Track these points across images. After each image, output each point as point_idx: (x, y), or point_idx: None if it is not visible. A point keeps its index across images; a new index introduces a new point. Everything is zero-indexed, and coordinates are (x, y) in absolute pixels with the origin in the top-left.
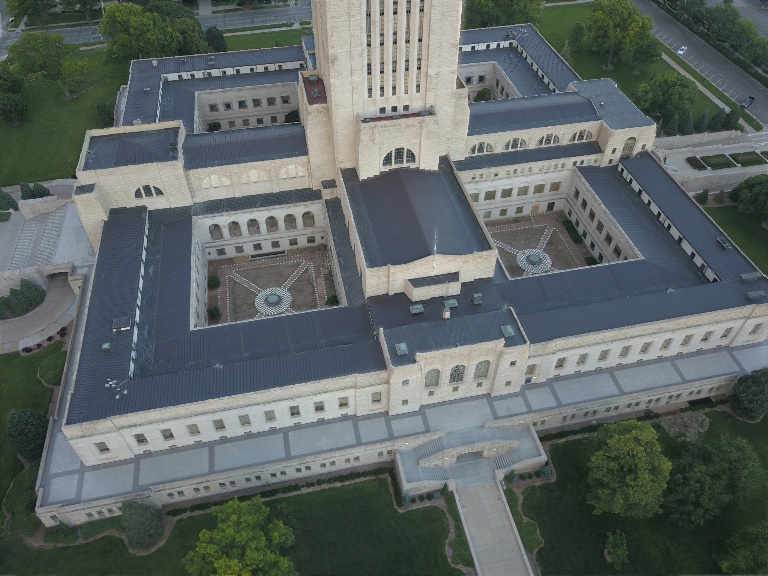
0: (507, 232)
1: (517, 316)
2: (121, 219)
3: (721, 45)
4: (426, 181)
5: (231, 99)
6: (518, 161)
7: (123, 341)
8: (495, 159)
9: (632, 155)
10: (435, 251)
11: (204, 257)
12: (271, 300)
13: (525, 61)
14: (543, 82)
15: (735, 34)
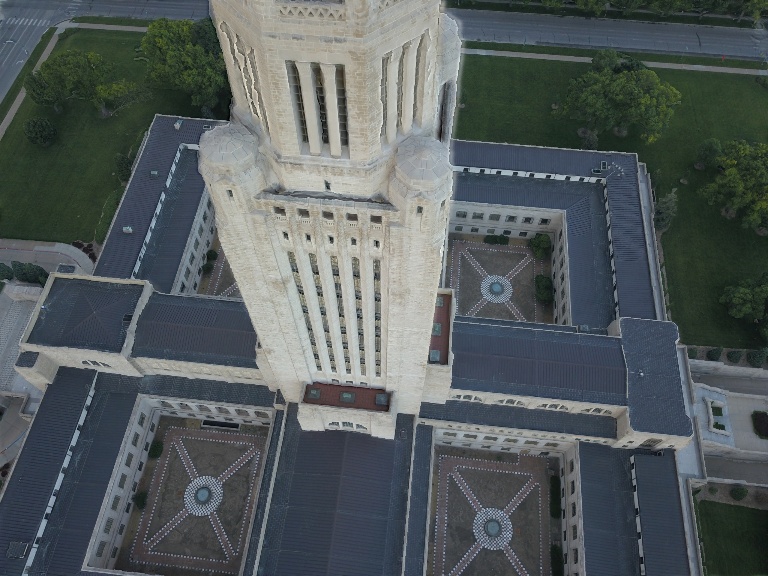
0: (482, 472)
1: None
2: (66, 384)
3: None
4: (372, 457)
5: None
6: (508, 422)
7: (13, 571)
8: (482, 411)
9: (655, 447)
10: None
11: (151, 422)
12: (200, 496)
13: (604, 216)
14: (610, 263)
15: None
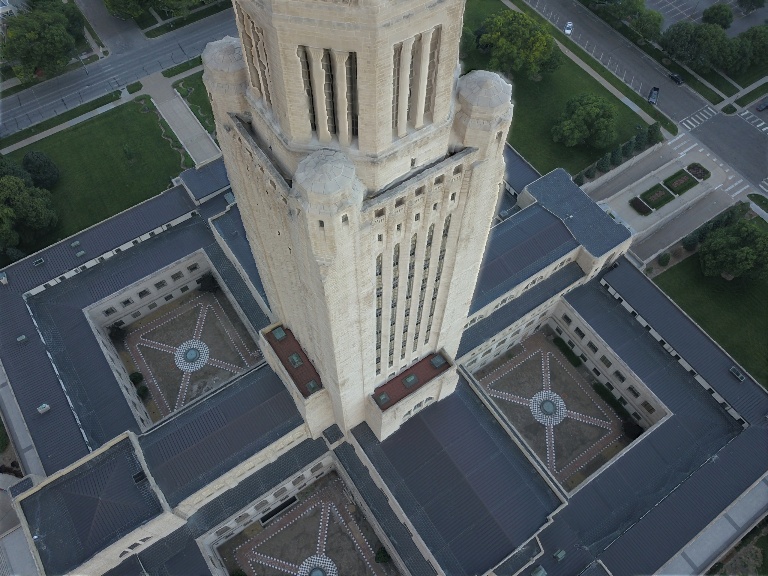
0: (507, 376)
1: (600, 555)
2: None
3: (601, 8)
4: (451, 417)
5: (129, 296)
6: (511, 318)
7: None
8: (488, 325)
9: (610, 263)
10: (515, 540)
11: (218, 559)
12: None
13: None
14: None
15: (622, 8)
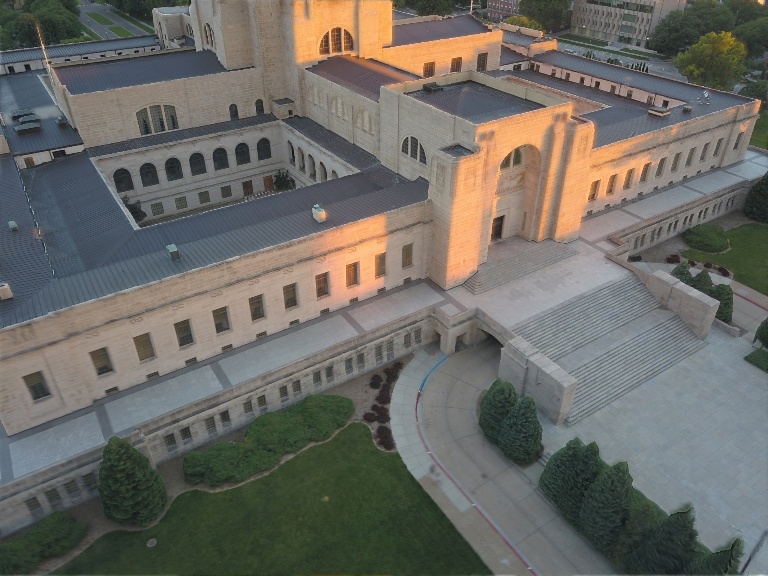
0: None
1: None
2: None
3: None
4: None
5: None
6: None
7: None
8: None
9: None
10: None
11: None
12: None
13: (33, 71)
14: None
15: None
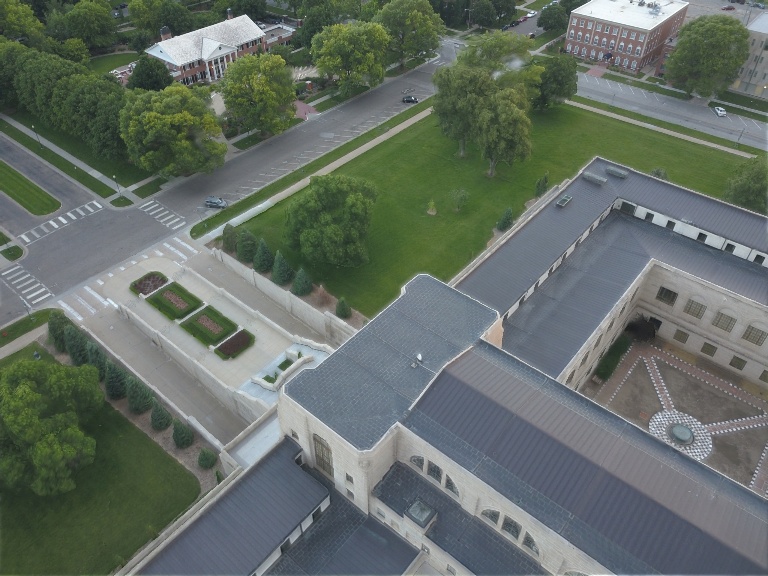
0: None
1: None
2: None
3: None
4: None
5: None
6: None
7: None
8: None
9: None
10: None
11: None
12: None
13: None
14: None
15: None
